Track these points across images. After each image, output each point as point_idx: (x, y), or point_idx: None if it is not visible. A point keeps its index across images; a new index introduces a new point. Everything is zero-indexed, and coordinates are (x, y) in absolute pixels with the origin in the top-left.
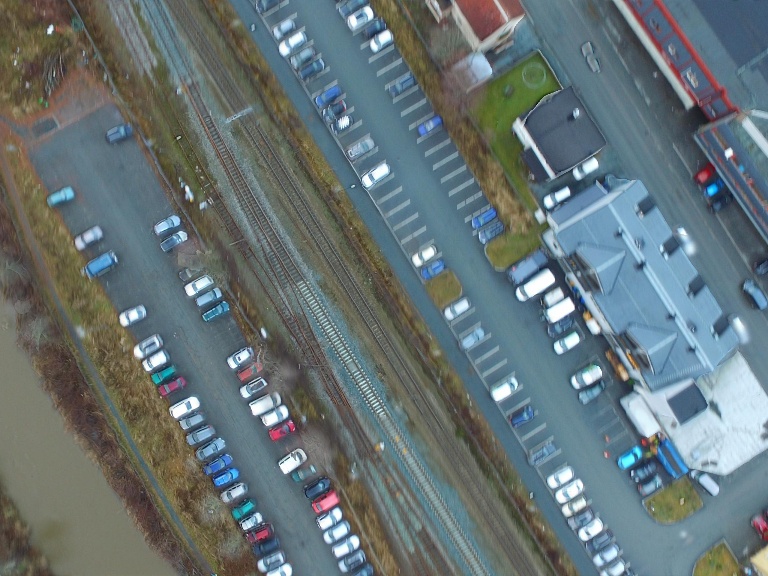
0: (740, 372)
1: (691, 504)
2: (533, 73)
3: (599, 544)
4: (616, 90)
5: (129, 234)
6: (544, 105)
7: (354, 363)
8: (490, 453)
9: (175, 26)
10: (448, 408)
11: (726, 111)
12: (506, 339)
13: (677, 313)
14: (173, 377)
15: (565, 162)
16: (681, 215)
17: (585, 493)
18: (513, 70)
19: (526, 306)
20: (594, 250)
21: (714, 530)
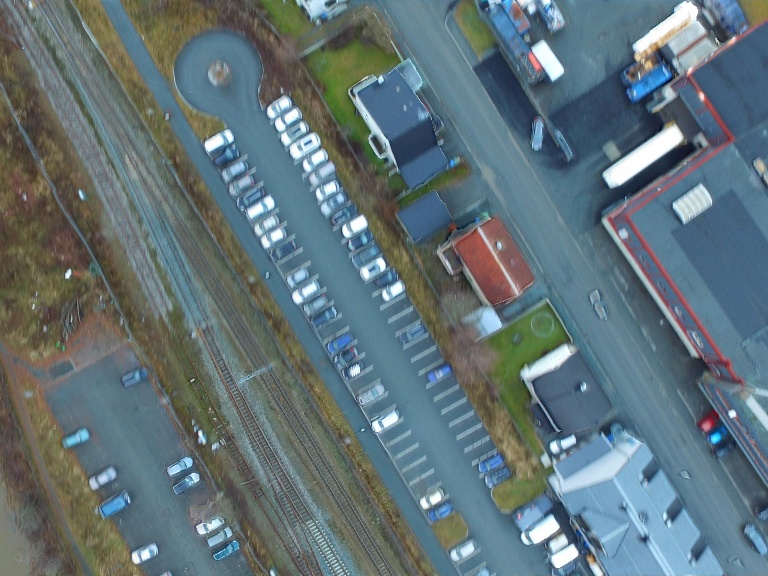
0: None
1: None
2: (541, 321)
3: None
4: (623, 337)
5: (142, 473)
6: (552, 372)
7: None
8: None
9: (191, 271)
10: None
11: (730, 379)
12: None
13: None
14: None
15: (572, 428)
16: (684, 459)
17: None
18: (522, 319)
19: (531, 548)
20: (599, 517)
21: None
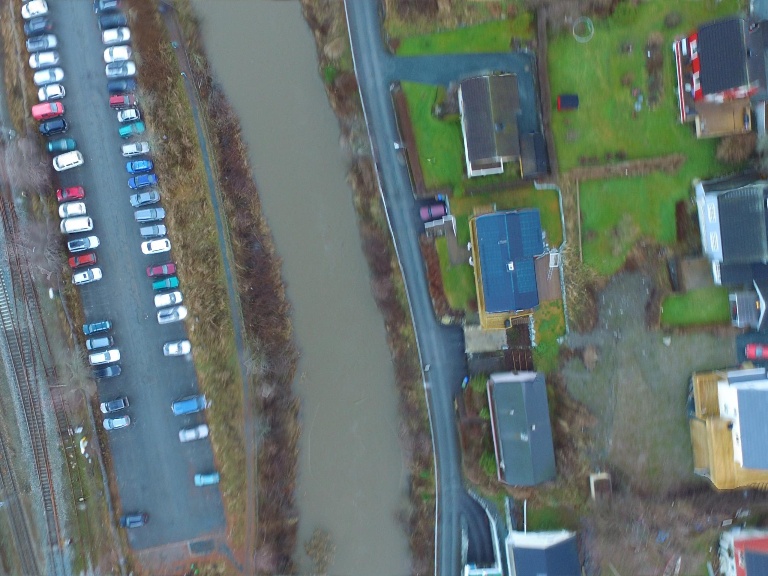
0: None
1: None
2: None
3: None
4: None
5: (159, 425)
6: None
7: None
8: None
9: None
10: None
11: None
12: None
13: None
14: (157, 279)
15: None
16: None
17: None
18: None
19: None
20: None
21: None
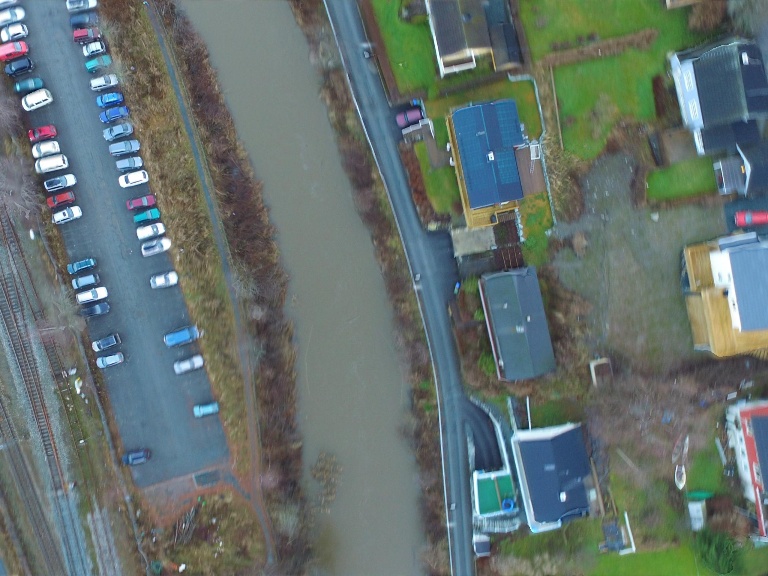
0: None
1: None
2: None
3: None
4: None
5: (153, 360)
6: None
7: None
8: None
9: (63, 548)
10: None
11: None
12: None
13: None
14: (137, 211)
15: None
16: None
17: None
18: None
19: None
20: None
21: None
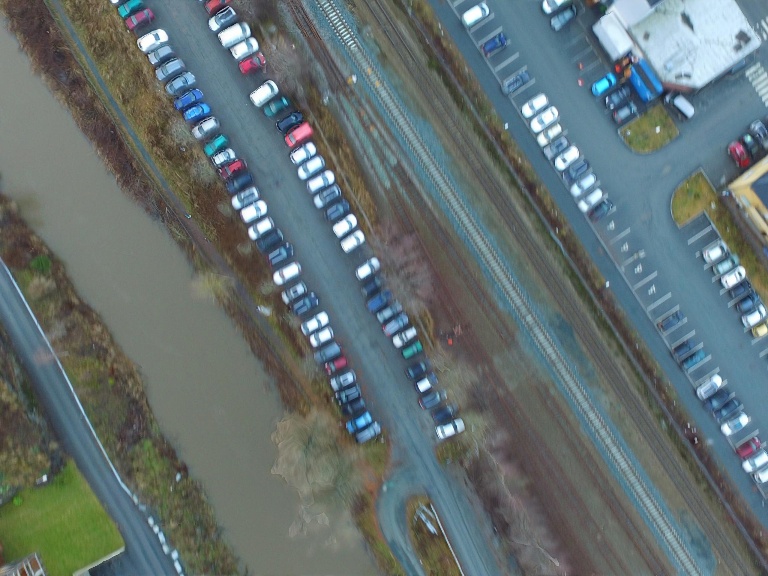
0: None
1: (667, 132)
2: None
3: (576, 170)
4: None
5: None
6: None
7: None
8: (463, 83)
9: None
10: (420, 39)
11: None
12: None
13: None
14: (140, 8)
15: None
16: None
17: (560, 123)
18: None
19: None
20: None
21: (691, 159)
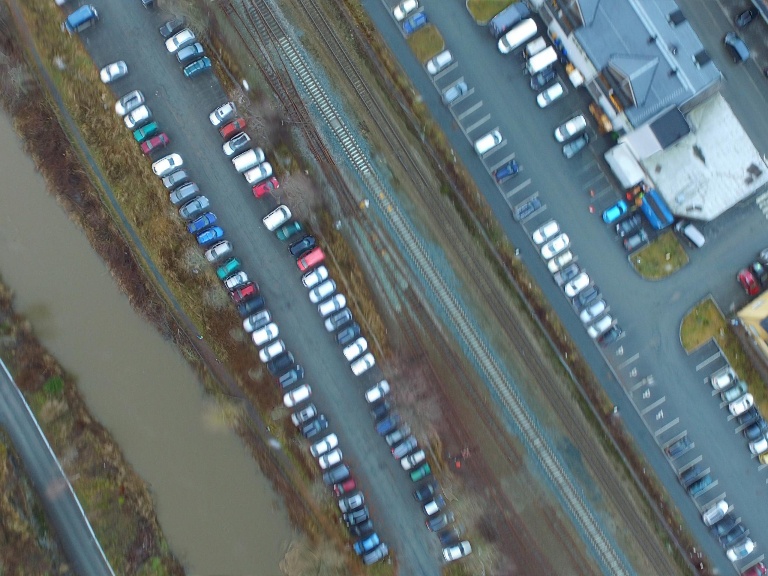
0: (723, 116)
1: (677, 259)
2: None
3: (586, 298)
4: None
5: None
6: None
7: (337, 120)
8: (475, 209)
9: None
10: (432, 165)
11: None
12: (489, 94)
13: (658, 35)
14: (155, 133)
15: None
16: None
17: (571, 249)
18: None
19: (509, 60)
20: None
21: (700, 286)
